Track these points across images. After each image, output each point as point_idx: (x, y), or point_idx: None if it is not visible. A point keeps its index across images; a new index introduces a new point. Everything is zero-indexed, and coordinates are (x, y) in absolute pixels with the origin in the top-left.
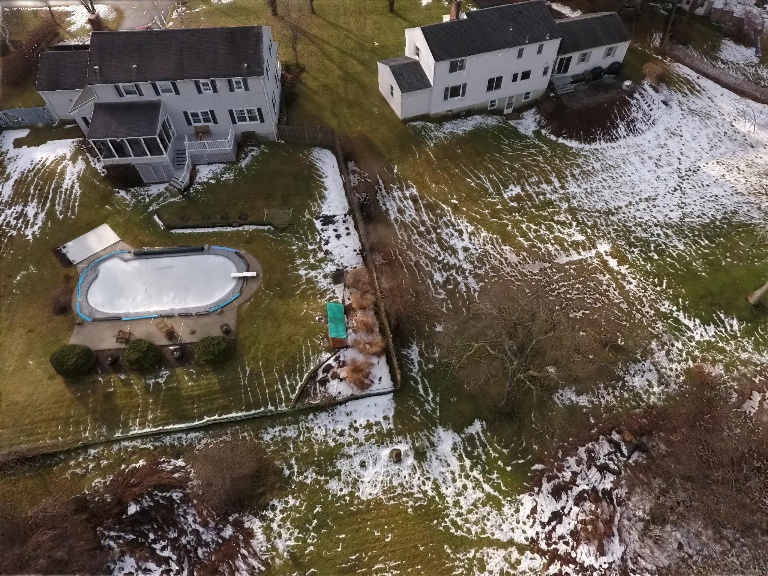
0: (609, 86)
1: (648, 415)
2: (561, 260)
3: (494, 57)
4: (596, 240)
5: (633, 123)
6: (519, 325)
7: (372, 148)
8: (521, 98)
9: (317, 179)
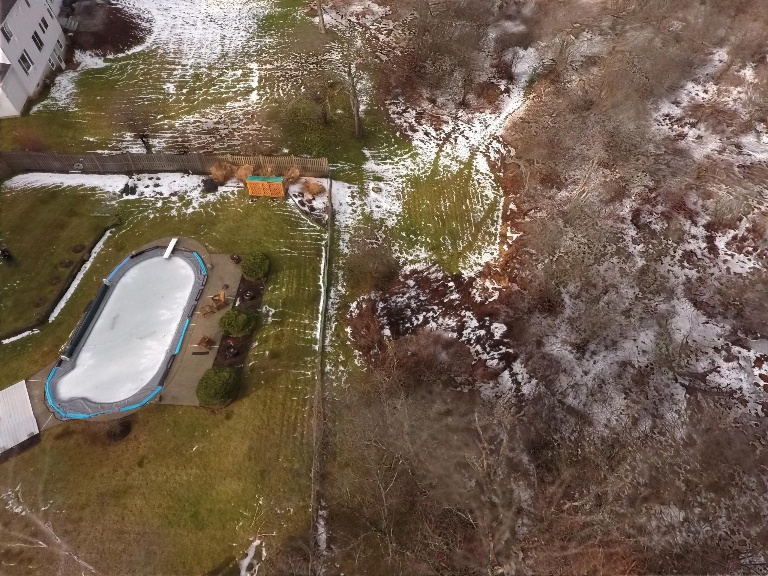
0: (90, 7)
1: (379, 89)
2: (255, 85)
3: (18, 12)
4: (246, 66)
5: (141, 17)
6: (301, 114)
7: (43, 146)
8: (59, 48)
9: (60, 189)
